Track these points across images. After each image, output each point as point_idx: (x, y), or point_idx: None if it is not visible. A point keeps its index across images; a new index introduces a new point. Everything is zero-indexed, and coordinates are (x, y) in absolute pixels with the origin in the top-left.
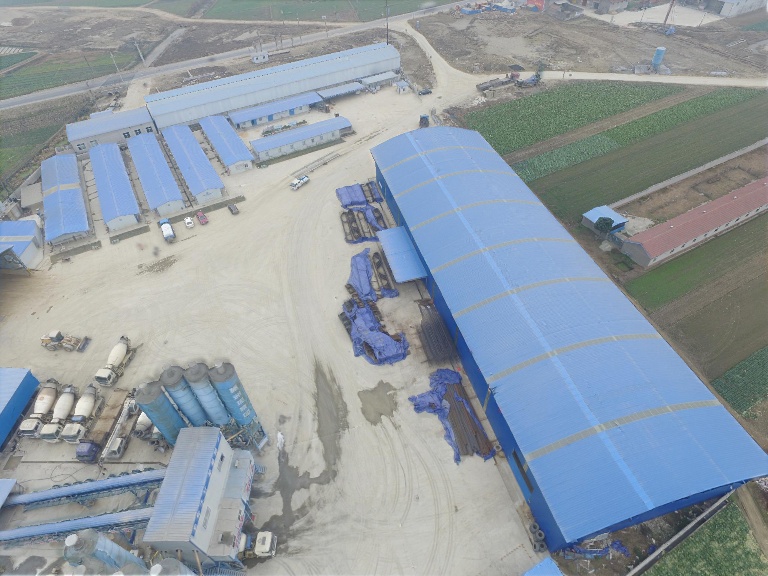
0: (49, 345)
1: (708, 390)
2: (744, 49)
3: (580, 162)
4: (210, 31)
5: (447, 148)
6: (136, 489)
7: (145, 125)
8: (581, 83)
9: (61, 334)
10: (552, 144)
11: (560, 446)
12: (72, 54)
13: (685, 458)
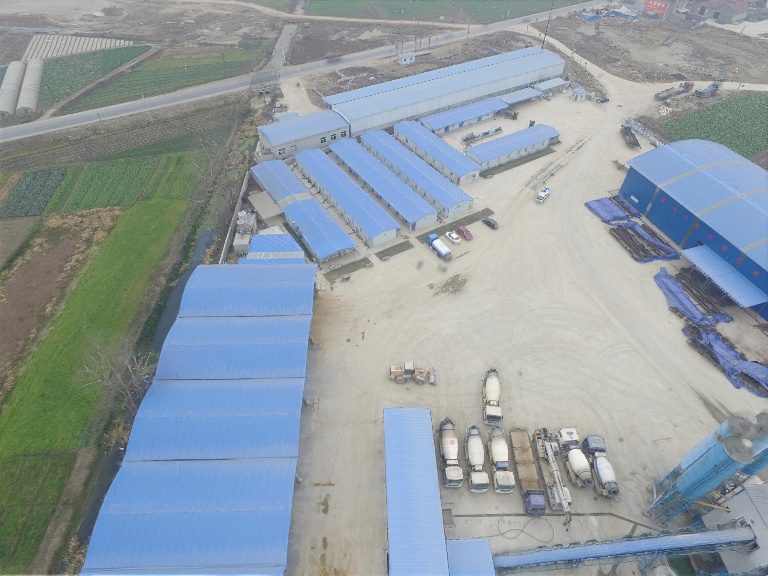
0: (401, 378)
1: None
2: None
3: None
4: (328, 29)
5: (725, 163)
6: None
7: (341, 129)
8: (755, 94)
9: (400, 365)
10: None
11: None
12: (190, 49)
13: None
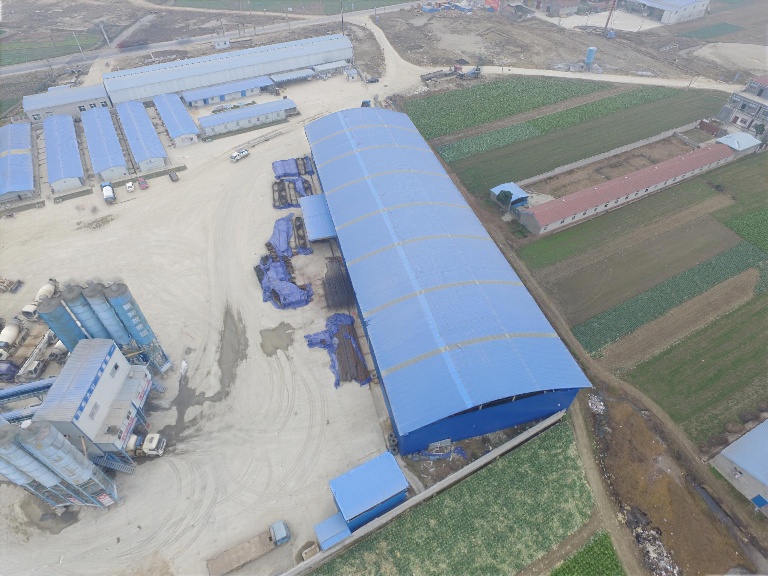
0: None
1: (550, 326)
2: (675, 53)
3: (502, 146)
4: (178, 18)
5: (371, 126)
6: (40, 393)
7: (100, 100)
8: (519, 78)
9: None
10: (480, 130)
11: (410, 363)
12: (41, 34)
13: (508, 371)
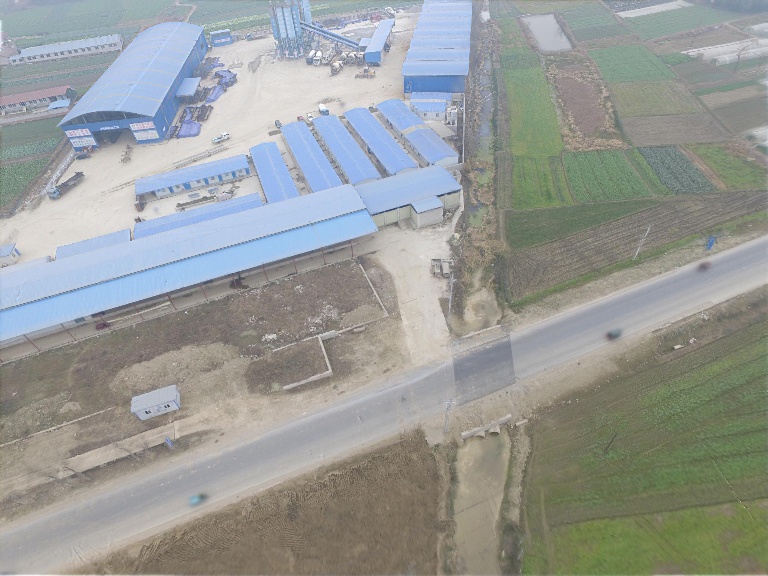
0: None
1: None
2: None
3: None
4: None
5: (107, 96)
6: None
7: None
8: None
9: None
10: None
11: None
12: None
13: None
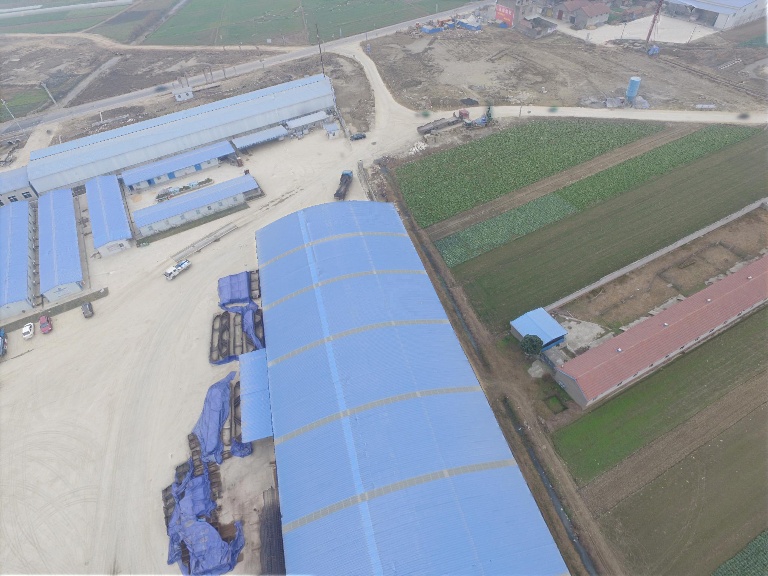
0: None
1: None
2: (739, 72)
3: (523, 235)
4: (143, 60)
5: (341, 236)
6: None
7: (20, 191)
8: (541, 121)
9: None
10: (494, 208)
11: None
12: None
13: None
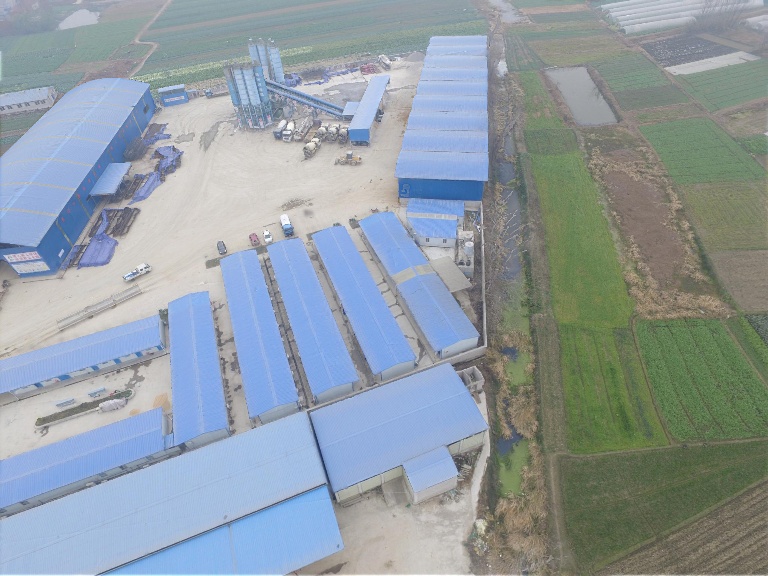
0: None
1: None
2: None
3: None
4: None
5: None
6: None
7: None
8: None
9: None
10: None
11: None
12: None
13: None
